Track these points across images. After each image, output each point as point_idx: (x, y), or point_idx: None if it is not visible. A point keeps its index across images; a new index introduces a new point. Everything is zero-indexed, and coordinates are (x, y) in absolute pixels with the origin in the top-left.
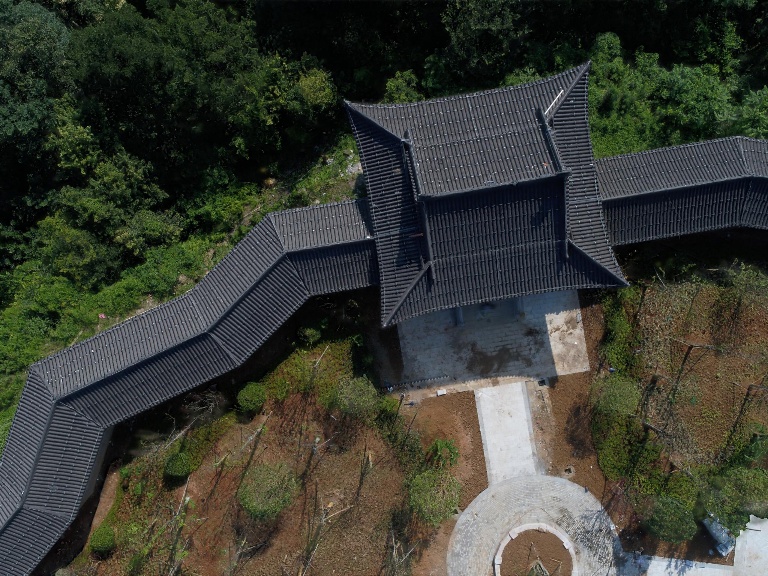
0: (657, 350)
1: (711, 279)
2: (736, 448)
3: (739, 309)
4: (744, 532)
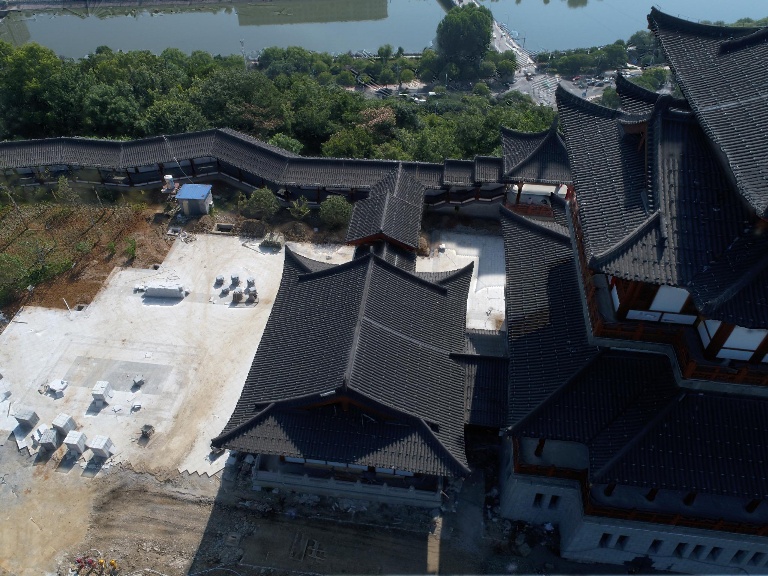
0: (5, 232)
1: (60, 205)
2: (28, 273)
3: (70, 216)
4: (14, 324)
